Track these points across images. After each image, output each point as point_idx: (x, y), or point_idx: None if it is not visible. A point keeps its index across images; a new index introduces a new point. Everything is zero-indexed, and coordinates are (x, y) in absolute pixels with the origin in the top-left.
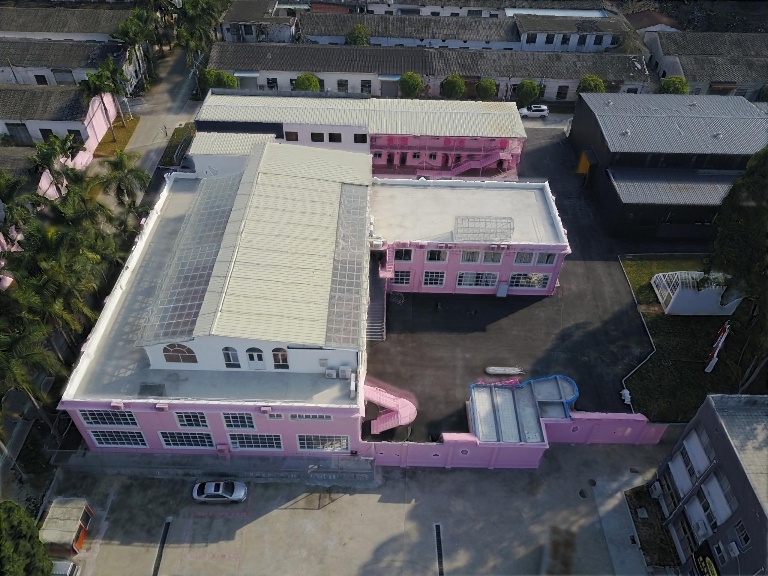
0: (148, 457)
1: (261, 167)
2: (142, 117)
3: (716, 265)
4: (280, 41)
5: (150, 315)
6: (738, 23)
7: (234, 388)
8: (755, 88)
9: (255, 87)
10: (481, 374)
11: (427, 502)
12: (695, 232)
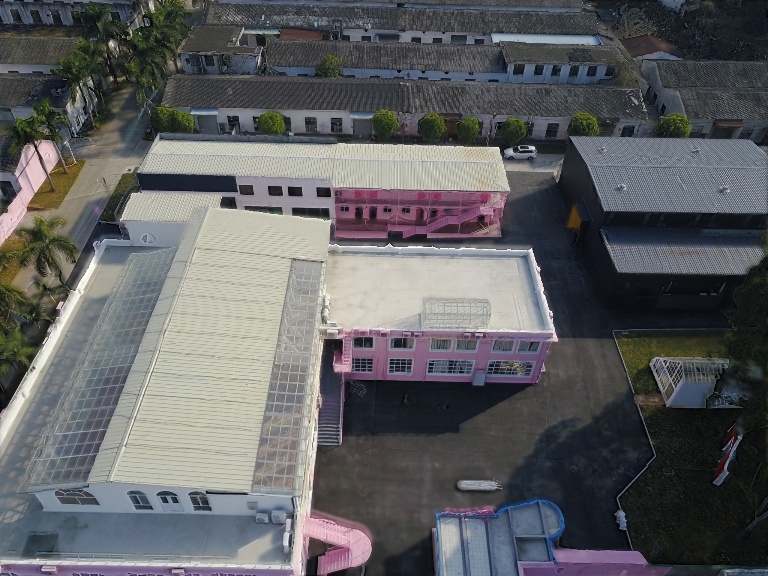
0: None
1: (198, 241)
2: (87, 161)
3: (729, 384)
4: (244, 73)
5: (44, 445)
6: (743, 49)
7: (142, 539)
8: (763, 126)
9: (215, 125)
10: (451, 490)
11: None
12: (700, 303)
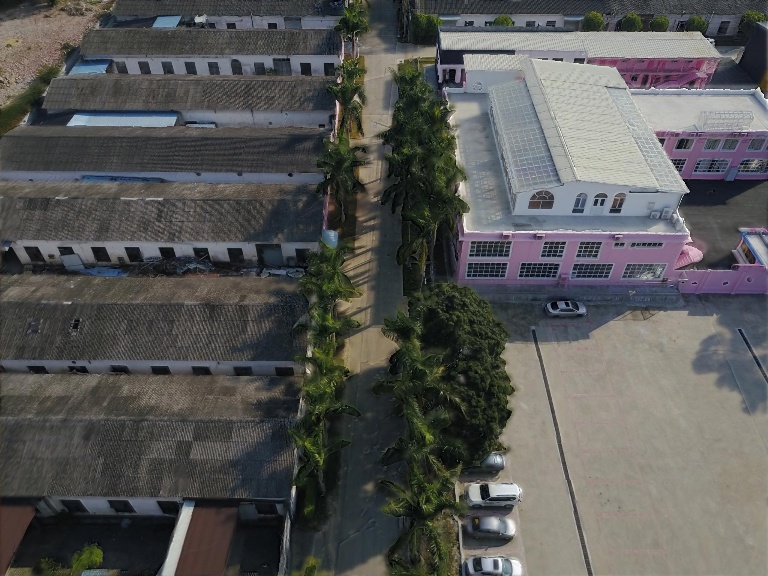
0: (503, 287)
1: (539, 75)
2: (366, 56)
3: None
4: None
5: (511, 174)
6: None
7: (585, 225)
8: None
9: None
10: (736, 233)
11: (725, 315)
12: None
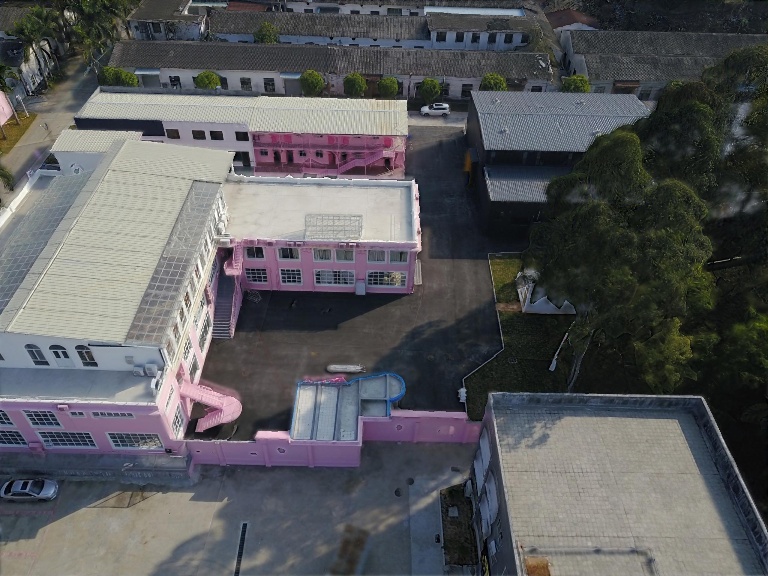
0: None
1: (113, 164)
2: (39, 115)
3: (527, 263)
4: (189, 39)
5: None
6: (659, 22)
7: (38, 386)
8: (659, 87)
9: (158, 85)
10: (321, 372)
11: (239, 501)
12: None
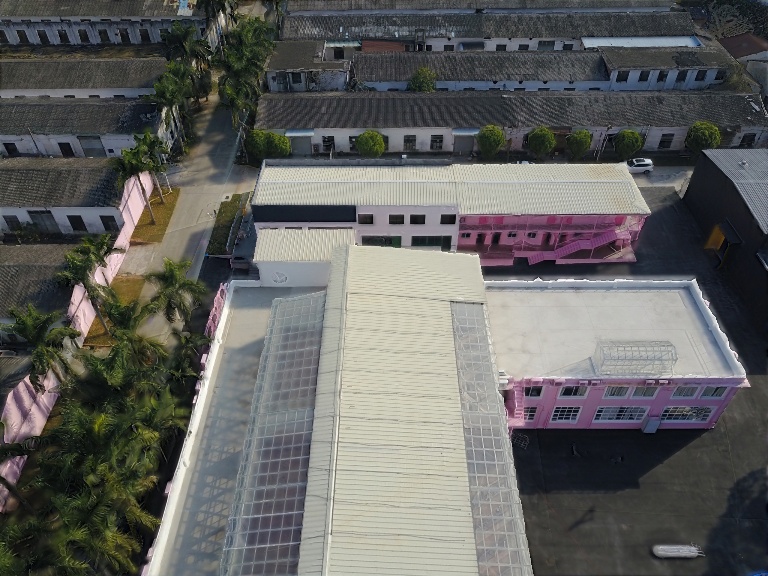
0: None
1: (348, 284)
2: (182, 189)
3: None
4: (333, 89)
5: (232, 530)
6: None
7: None
8: None
9: (308, 146)
10: (648, 557)
11: None
12: None
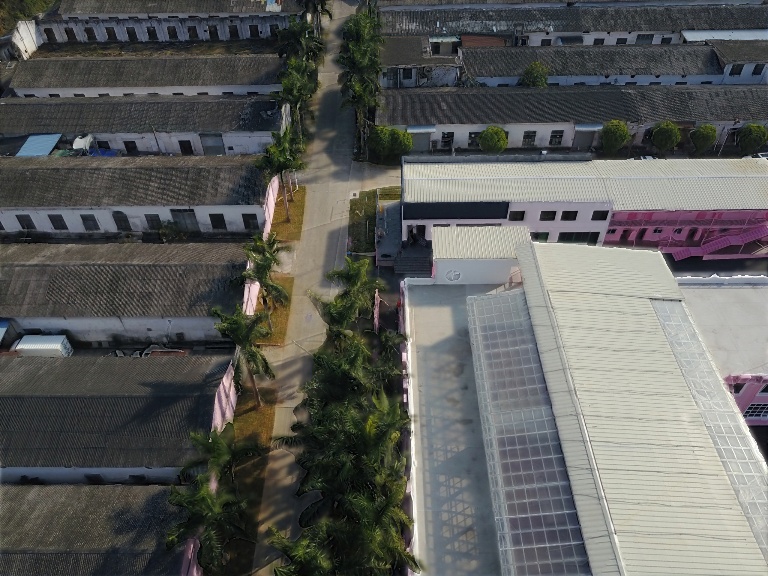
0: None
1: (545, 282)
2: (308, 186)
3: None
4: (443, 85)
5: (502, 530)
6: None
7: None
8: None
9: (426, 142)
10: None
11: None
12: None
